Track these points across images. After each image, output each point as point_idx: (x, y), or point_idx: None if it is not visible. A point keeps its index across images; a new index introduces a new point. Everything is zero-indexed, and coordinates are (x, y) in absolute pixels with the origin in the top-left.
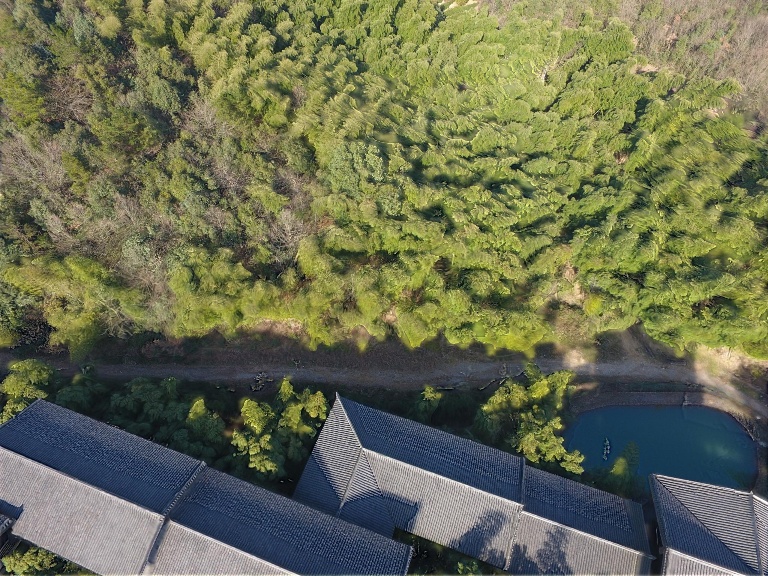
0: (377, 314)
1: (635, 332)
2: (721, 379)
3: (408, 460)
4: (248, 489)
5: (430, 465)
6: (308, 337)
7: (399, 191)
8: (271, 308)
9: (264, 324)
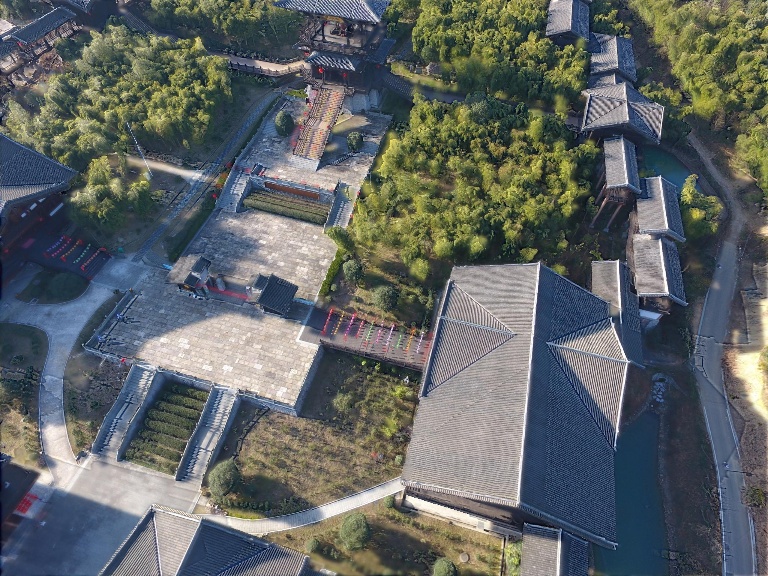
0: (680, 44)
1: (753, 185)
2: (745, 224)
3: (618, 47)
4: (588, 14)
5: (619, 51)
6: (653, 51)
7: (764, 22)
8: (661, 13)
9: (651, 37)
